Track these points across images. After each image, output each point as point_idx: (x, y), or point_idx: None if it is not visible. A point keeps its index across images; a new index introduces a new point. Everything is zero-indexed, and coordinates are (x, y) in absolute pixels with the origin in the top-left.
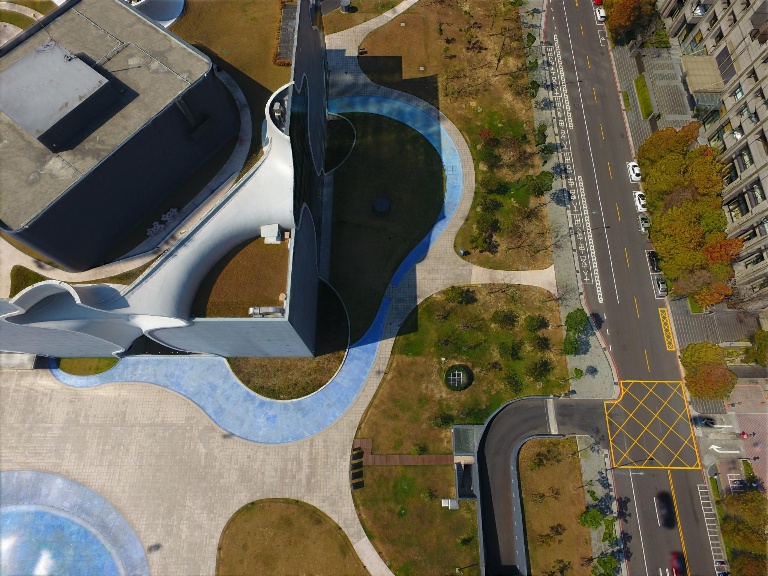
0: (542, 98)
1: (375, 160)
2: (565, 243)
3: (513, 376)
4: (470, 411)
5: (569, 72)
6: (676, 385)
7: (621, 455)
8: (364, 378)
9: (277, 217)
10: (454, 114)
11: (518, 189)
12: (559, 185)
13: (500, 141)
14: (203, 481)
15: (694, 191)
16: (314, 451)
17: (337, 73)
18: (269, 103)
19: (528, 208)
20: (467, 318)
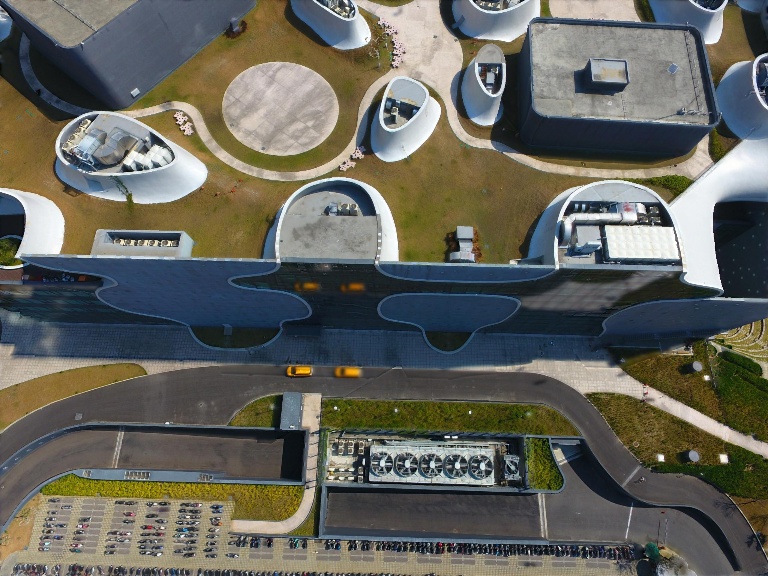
0: None
1: None
2: None
3: None
4: None
5: None
6: None
7: None
8: None
9: None
10: None
11: None
12: None
13: None
14: None
15: None
16: None
17: None
18: None
19: None
20: None
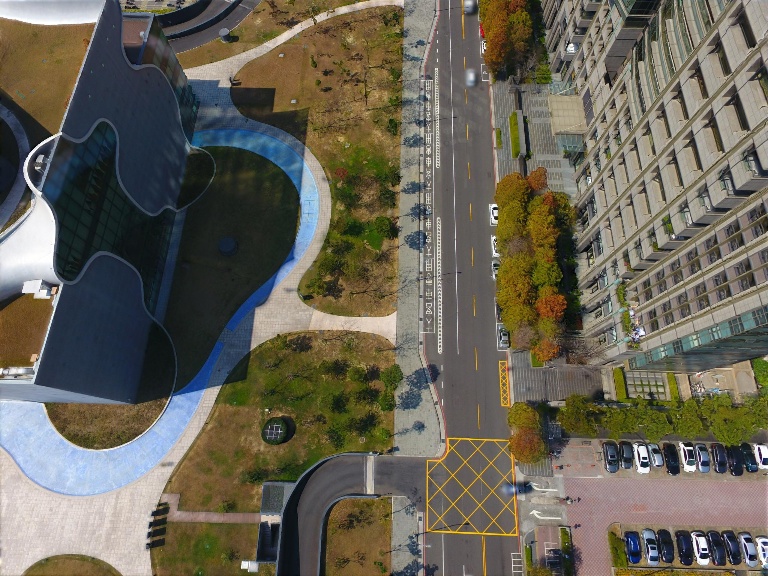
0: (412, 134)
1: (231, 197)
2: (412, 289)
3: (336, 430)
4: (286, 466)
5: (444, 107)
6: (505, 444)
7: (436, 518)
8: (183, 428)
9: (38, 273)
10: (320, 150)
11: (373, 230)
12: (415, 227)
13: (362, 179)
14: (0, 534)
15: (531, 241)
16: (119, 505)
17: (207, 105)
18: (30, 156)
19: (380, 250)
20: (298, 366)
